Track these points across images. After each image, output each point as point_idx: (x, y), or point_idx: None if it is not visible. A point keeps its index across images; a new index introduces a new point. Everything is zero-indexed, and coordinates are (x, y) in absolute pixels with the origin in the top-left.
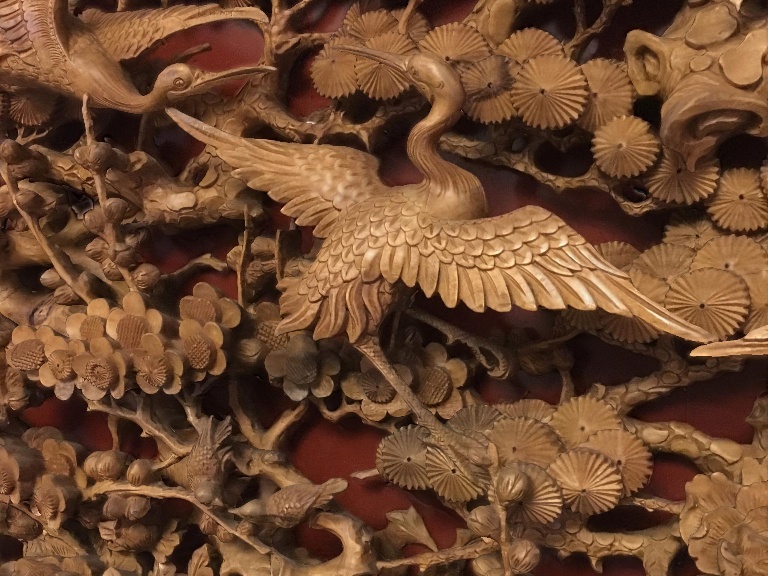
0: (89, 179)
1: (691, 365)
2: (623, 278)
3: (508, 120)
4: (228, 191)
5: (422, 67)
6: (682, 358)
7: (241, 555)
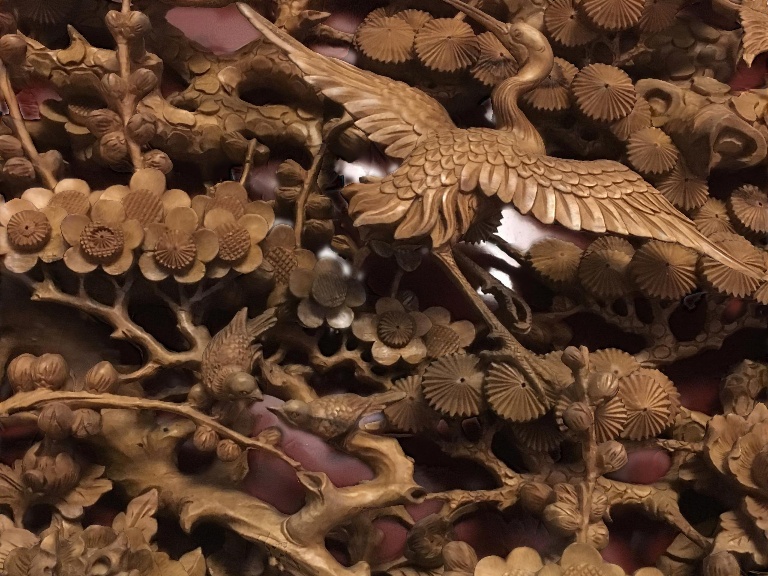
0: (71, 64)
1: (681, 341)
2: (692, 224)
3: (558, 110)
4: (228, 125)
5: (528, 31)
6: (673, 335)
7: (220, 493)
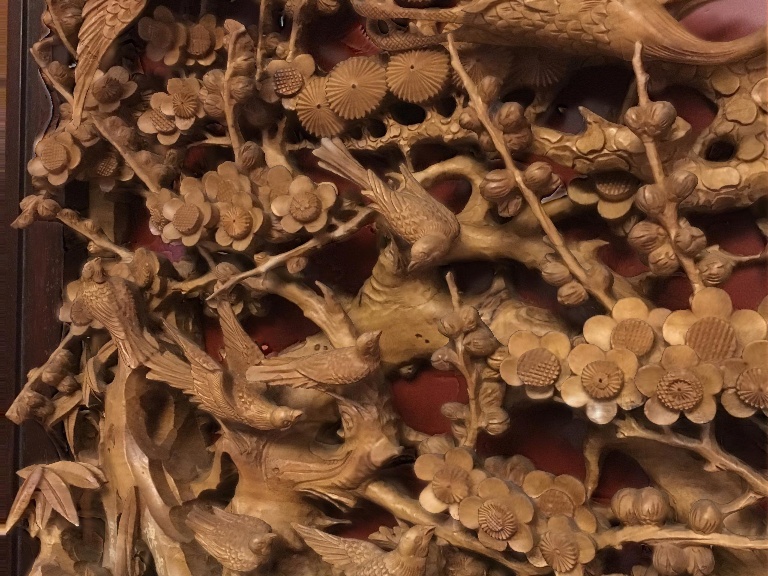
0: (592, 152)
1: None
2: None
3: None
4: None
5: None
6: None
7: None
